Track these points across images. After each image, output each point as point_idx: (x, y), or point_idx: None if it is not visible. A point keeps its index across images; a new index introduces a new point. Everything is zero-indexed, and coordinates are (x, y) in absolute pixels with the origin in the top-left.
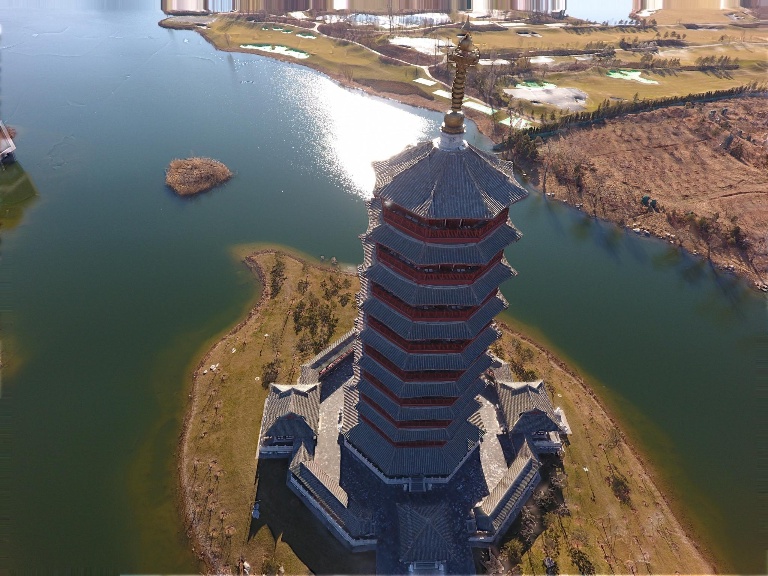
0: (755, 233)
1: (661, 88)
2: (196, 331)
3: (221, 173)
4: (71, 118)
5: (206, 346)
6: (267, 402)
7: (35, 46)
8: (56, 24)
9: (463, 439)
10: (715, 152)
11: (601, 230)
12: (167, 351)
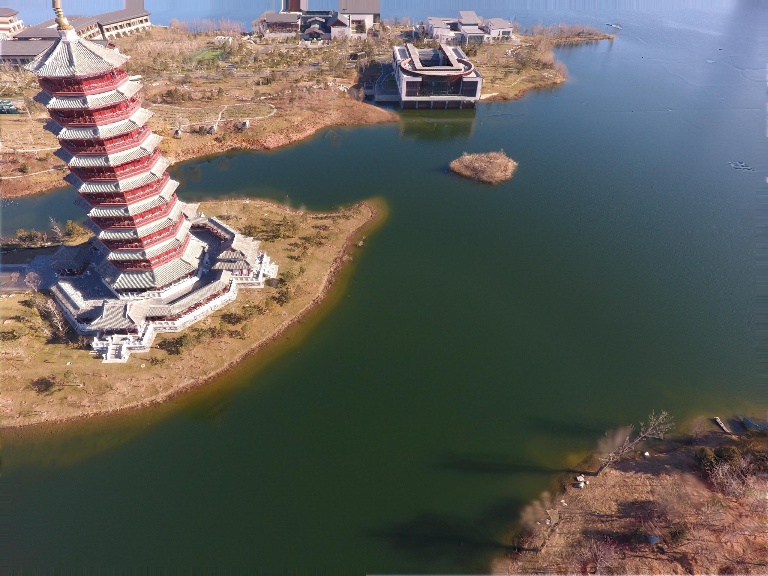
0: None
1: None
2: (286, 196)
3: (488, 175)
4: (558, 109)
5: (270, 200)
6: None
7: (687, 68)
8: (765, 62)
9: (113, 274)
10: None
11: (470, 541)
12: (271, 189)
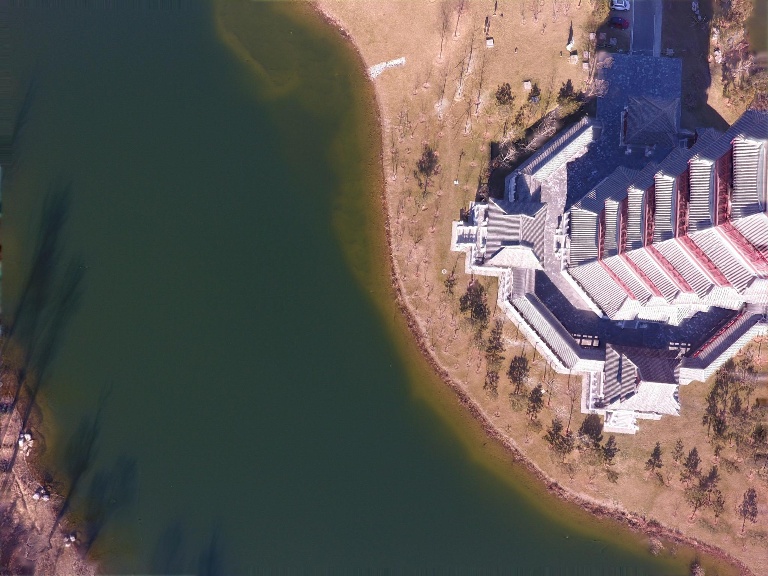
0: None
1: None
2: None
3: None
4: None
5: None
6: None
7: None
8: None
9: (602, 198)
10: None
11: None
12: None
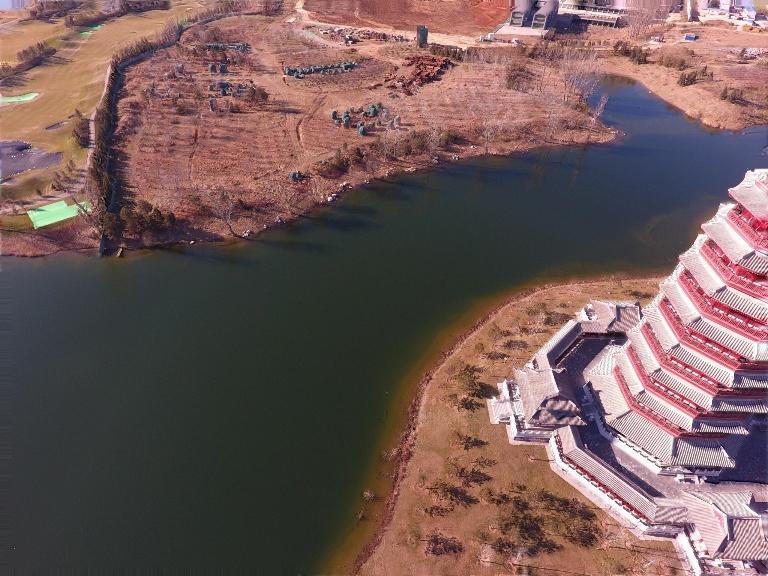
0: (357, 146)
1: (54, 96)
2: None
3: None
4: None
5: None
6: (709, 575)
7: None
8: None
9: None
10: (224, 117)
11: (325, 219)
12: None
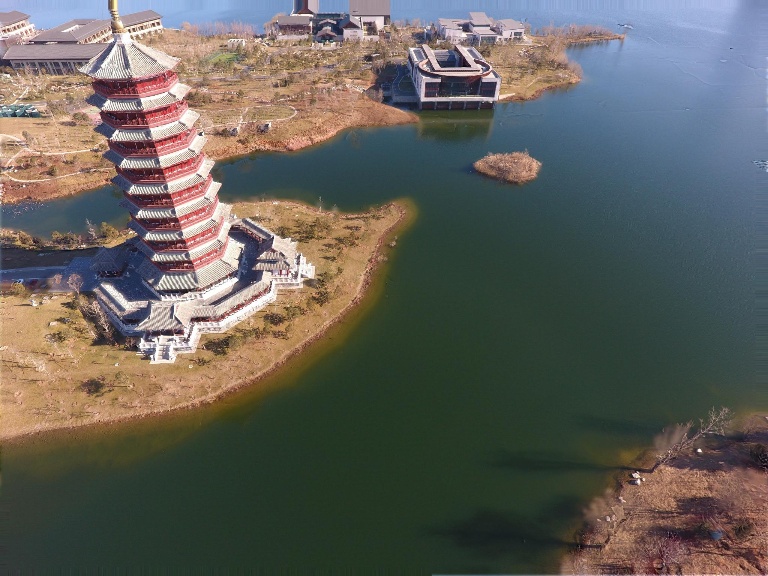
0: None
1: None
2: (314, 197)
3: (513, 175)
4: (576, 109)
5: (299, 201)
6: None
7: (701, 67)
8: None
9: (154, 276)
10: None
11: (533, 539)
12: (298, 191)
